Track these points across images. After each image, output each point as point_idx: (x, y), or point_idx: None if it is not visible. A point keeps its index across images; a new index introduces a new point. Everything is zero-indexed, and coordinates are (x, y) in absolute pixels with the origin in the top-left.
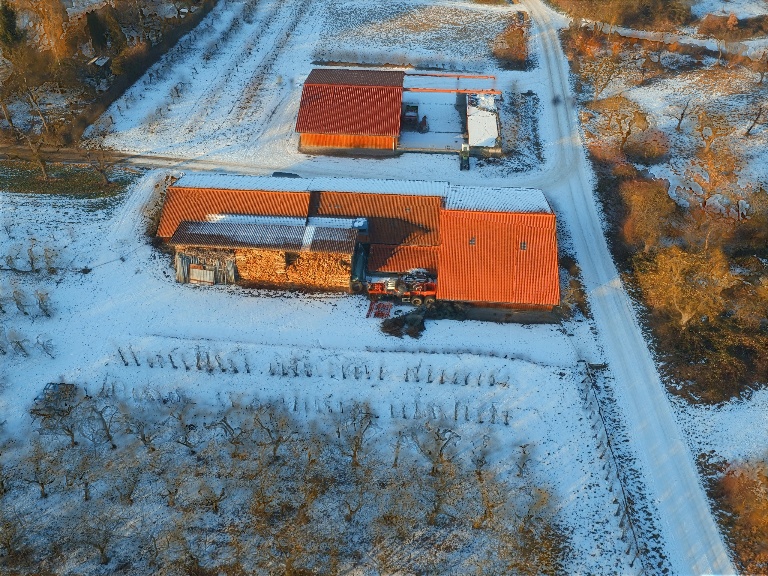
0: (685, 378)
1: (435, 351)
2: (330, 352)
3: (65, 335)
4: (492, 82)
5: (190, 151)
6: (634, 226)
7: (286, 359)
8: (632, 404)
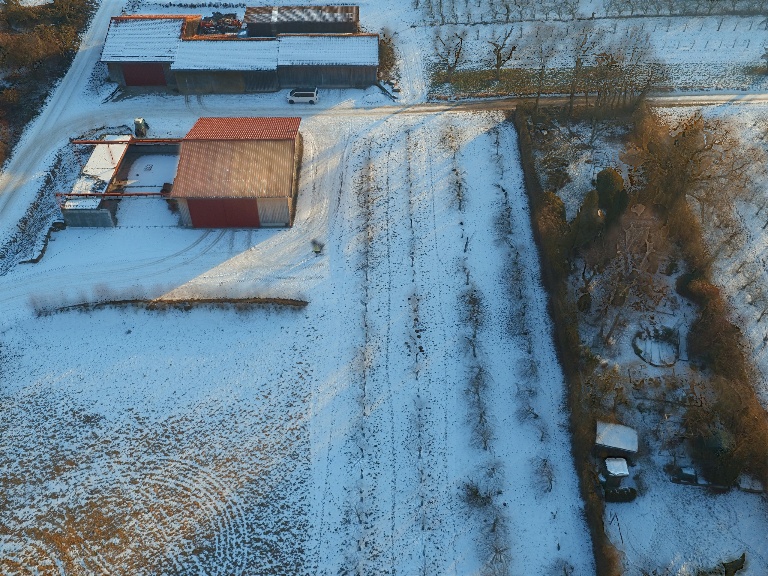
0: (88, 5)
1: (210, 3)
2: (263, 3)
3: (401, 3)
4: (36, 291)
5: (401, 120)
6: (52, 43)
7: (285, 0)
8: (121, 0)
